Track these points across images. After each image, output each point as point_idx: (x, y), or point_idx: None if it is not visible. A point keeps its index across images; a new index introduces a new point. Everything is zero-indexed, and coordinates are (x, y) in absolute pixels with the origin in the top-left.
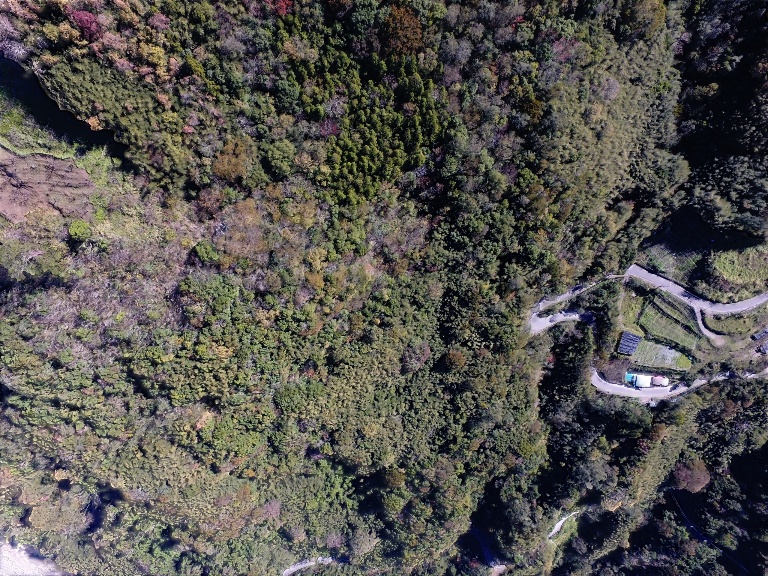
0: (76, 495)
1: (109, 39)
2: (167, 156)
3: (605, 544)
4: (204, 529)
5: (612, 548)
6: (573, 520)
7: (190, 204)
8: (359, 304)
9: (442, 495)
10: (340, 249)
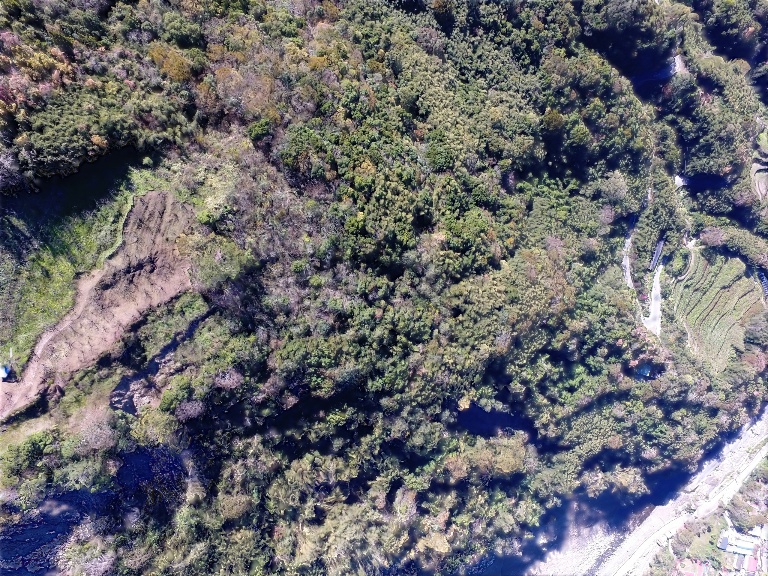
0: None
1: (15, 81)
2: (151, 111)
3: None
4: (557, 310)
5: None
6: None
7: (210, 135)
8: (357, 53)
9: (583, 79)
10: (292, 32)
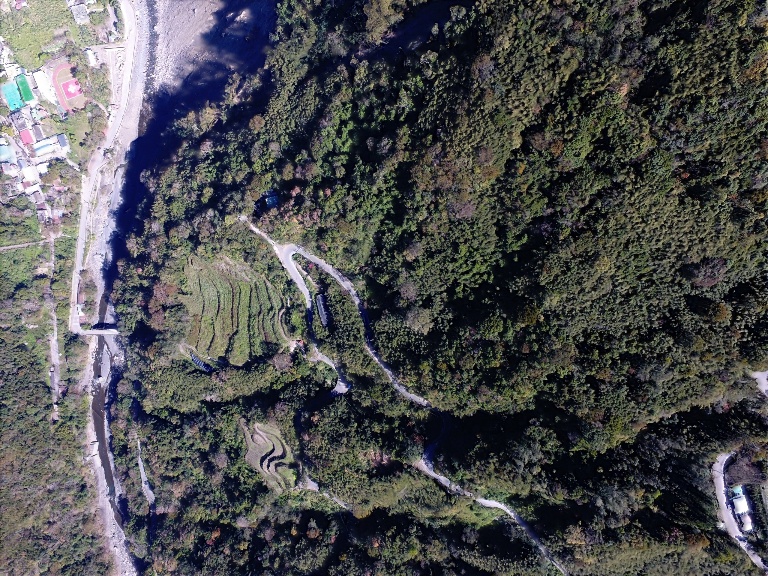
0: (454, 14)
1: None
2: None
3: (490, 557)
4: (430, 151)
5: (486, 567)
6: (494, 518)
7: None
8: None
9: None
10: None
